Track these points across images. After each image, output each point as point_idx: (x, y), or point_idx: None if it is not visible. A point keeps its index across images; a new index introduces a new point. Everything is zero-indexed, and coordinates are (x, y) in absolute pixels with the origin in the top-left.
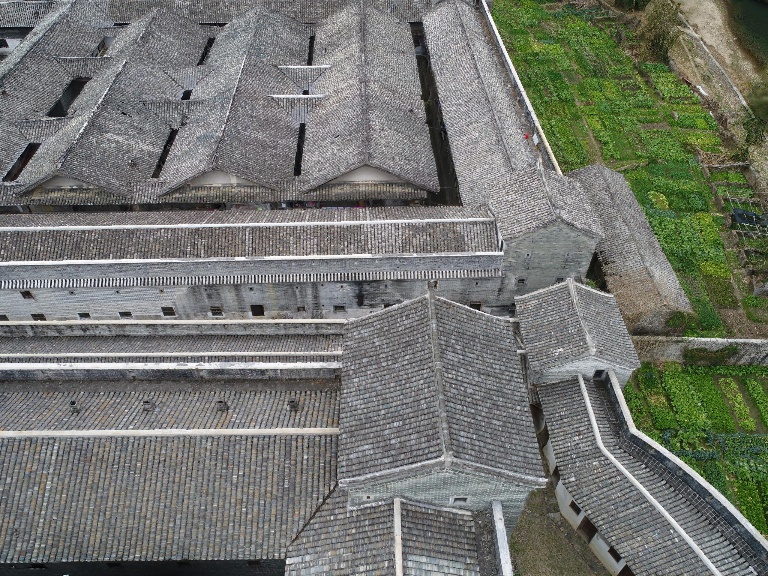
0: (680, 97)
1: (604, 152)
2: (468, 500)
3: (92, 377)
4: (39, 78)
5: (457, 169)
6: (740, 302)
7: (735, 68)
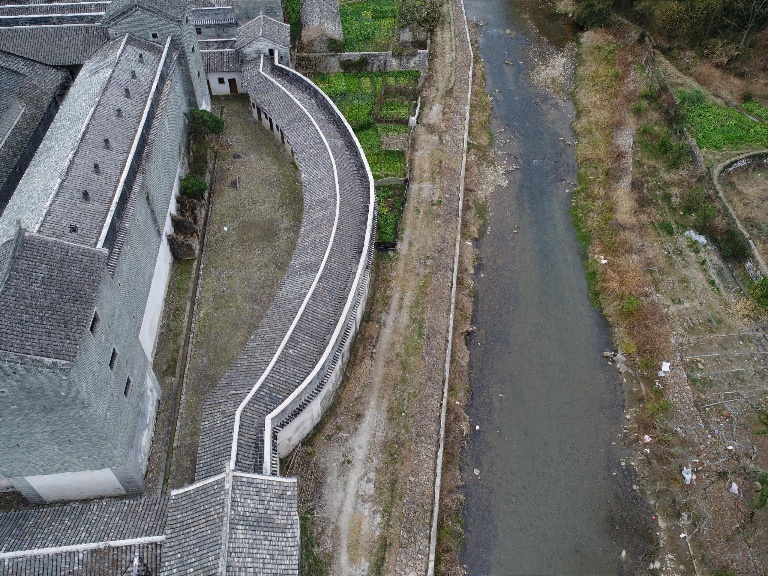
0: None
1: None
2: (158, 35)
3: (3, 25)
4: None
5: None
6: None
7: None
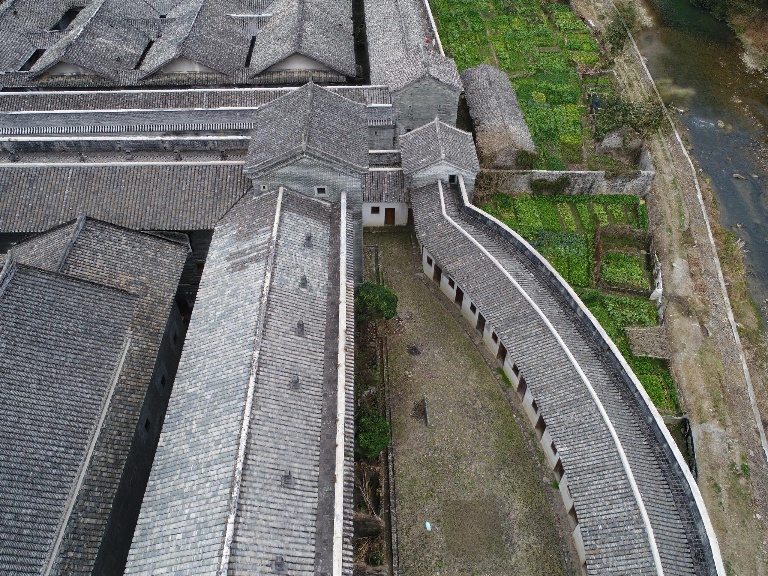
0: (574, 29)
1: (502, 65)
2: (326, 190)
3: (92, 148)
4: (42, 5)
5: (371, 62)
6: (585, 159)
7: (631, 12)
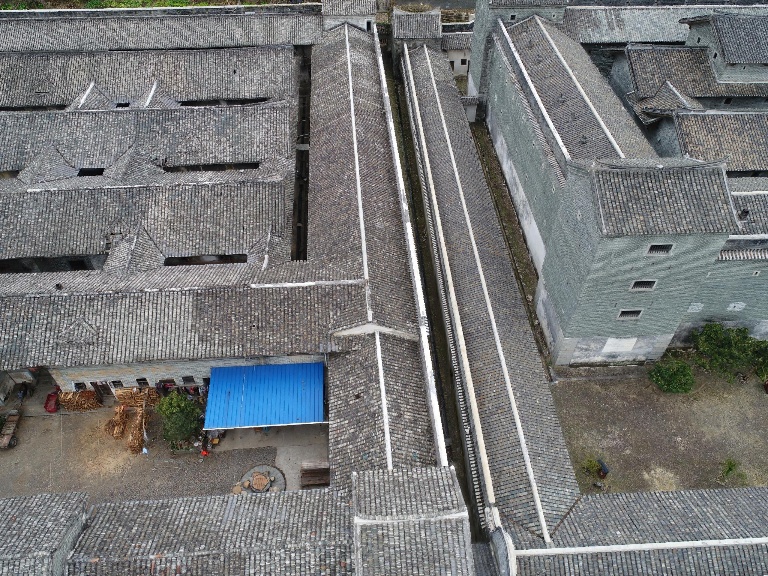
0: None
1: None
2: None
3: None
4: None
5: (274, 43)
6: None
7: None
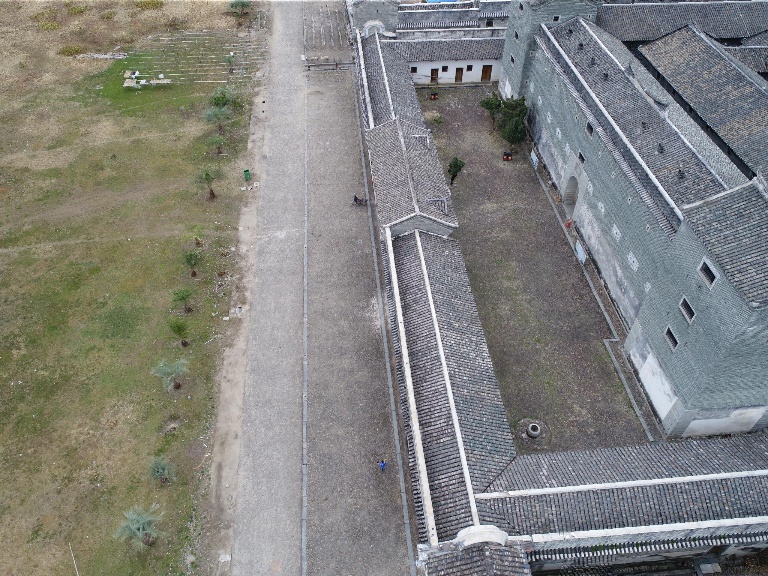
0: None
1: None
2: None
3: (714, 0)
4: None
5: None
6: None
7: None
